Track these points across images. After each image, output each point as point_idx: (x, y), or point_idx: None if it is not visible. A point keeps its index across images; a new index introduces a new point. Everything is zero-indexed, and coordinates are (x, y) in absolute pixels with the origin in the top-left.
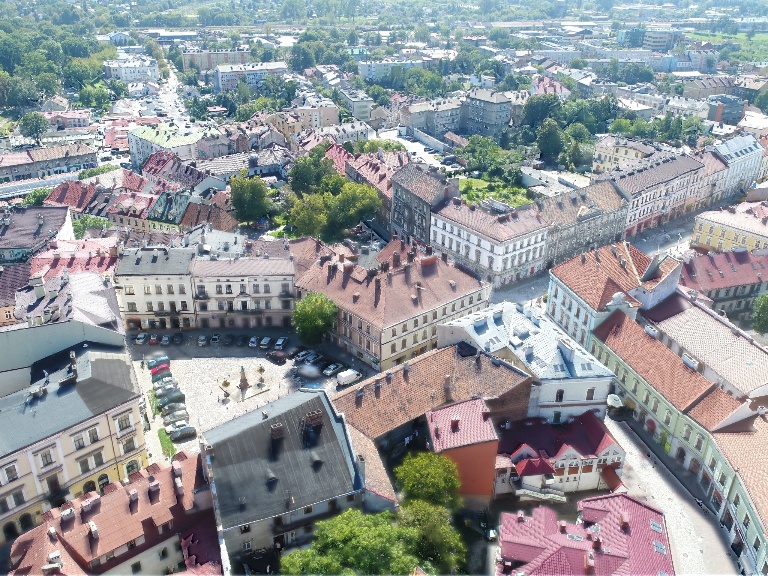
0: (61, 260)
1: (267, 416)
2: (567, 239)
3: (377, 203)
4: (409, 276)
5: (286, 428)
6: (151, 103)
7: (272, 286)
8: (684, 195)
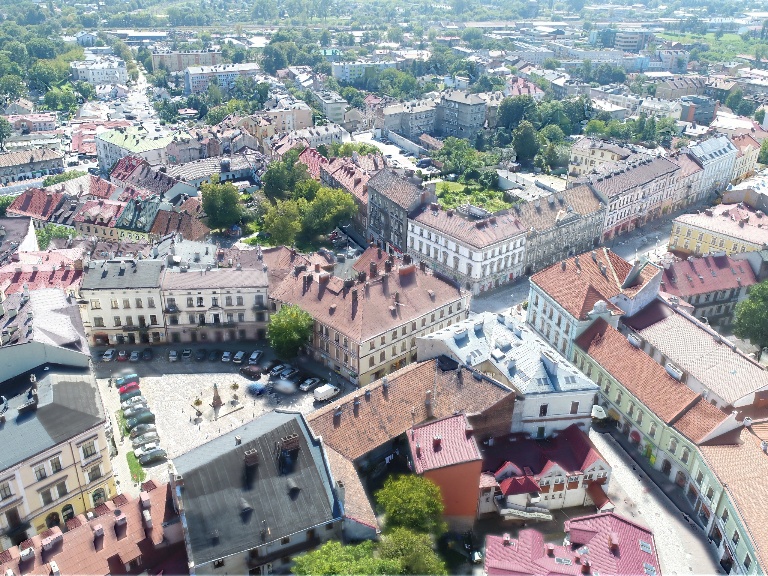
0: (23, 274)
1: (241, 441)
2: (546, 244)
3: (353, 209)
4: (387, 286)
5: (261, 454)
6: (120, 106)
7: (245, 298)
8: (660, 197)
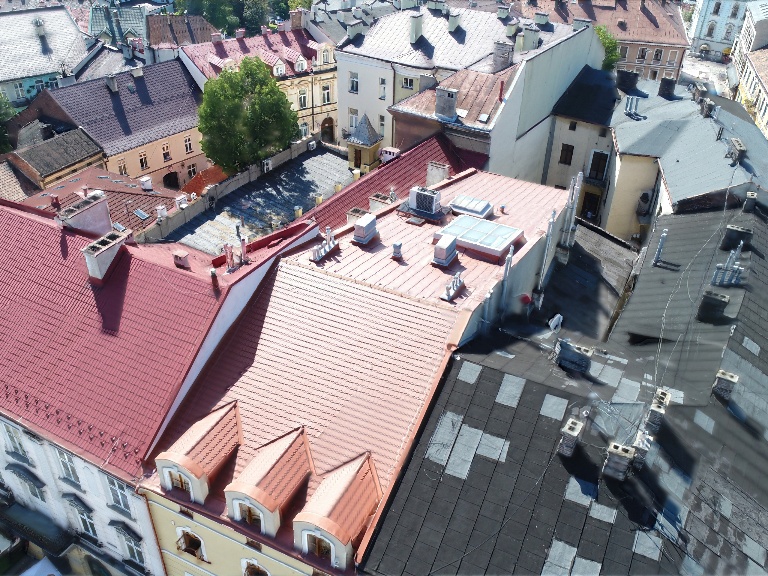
0: (225, 44)
1: None
2: None
3: None
4: None
5: None
6: None
7: None
8: None
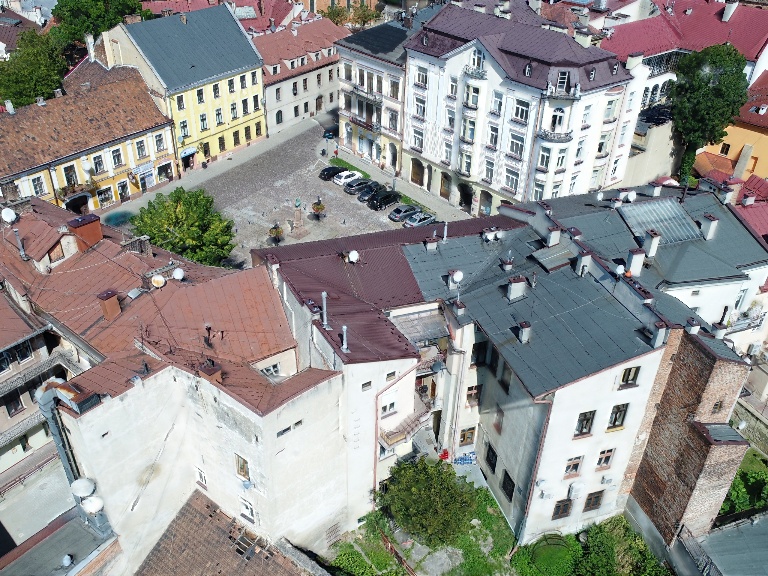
0: None
1: None
2: None
3: None
4: None
5: None
6: None
7: None
8: None
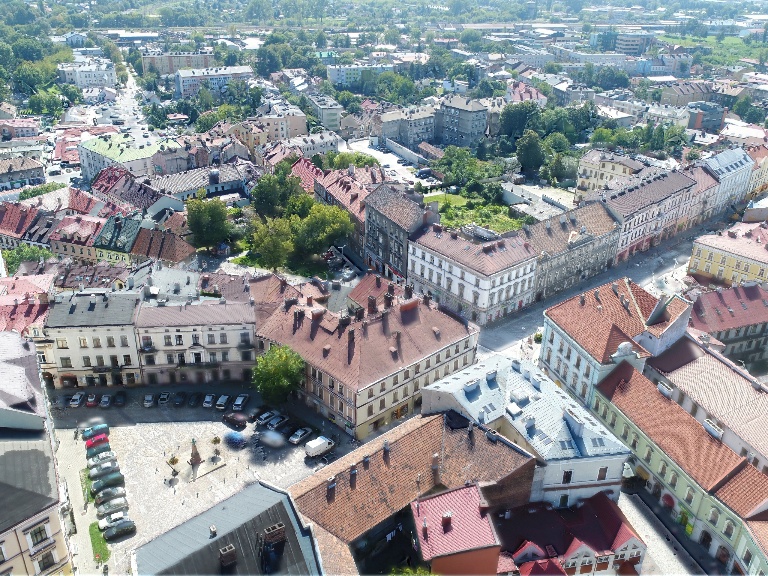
0: None
1: (216, 533)
2: (557, 268)
3: (349, 227)
4: (387, 325)
5: (239, 549)
6: (107, 110)
7: (229, 336)
8: (676, 214)
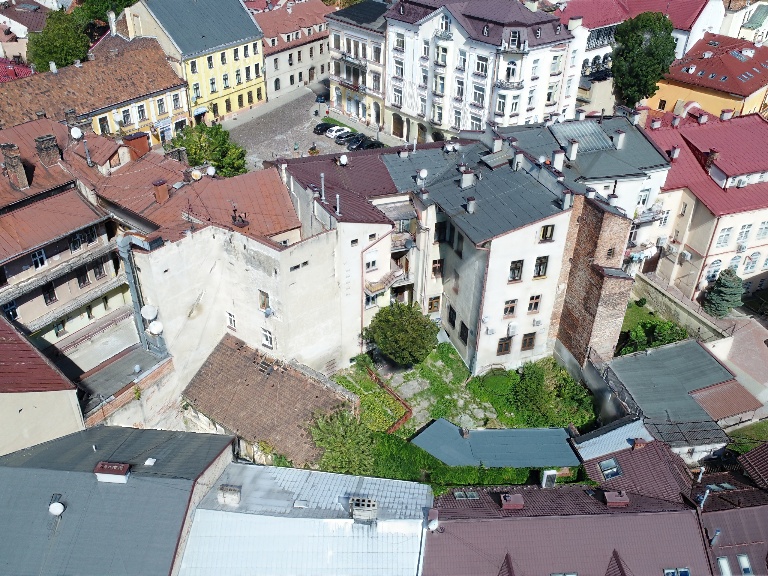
0: (715, 120)
1: None
2: None
3: None
4: None
5: None
6: None
7: None
8: None
